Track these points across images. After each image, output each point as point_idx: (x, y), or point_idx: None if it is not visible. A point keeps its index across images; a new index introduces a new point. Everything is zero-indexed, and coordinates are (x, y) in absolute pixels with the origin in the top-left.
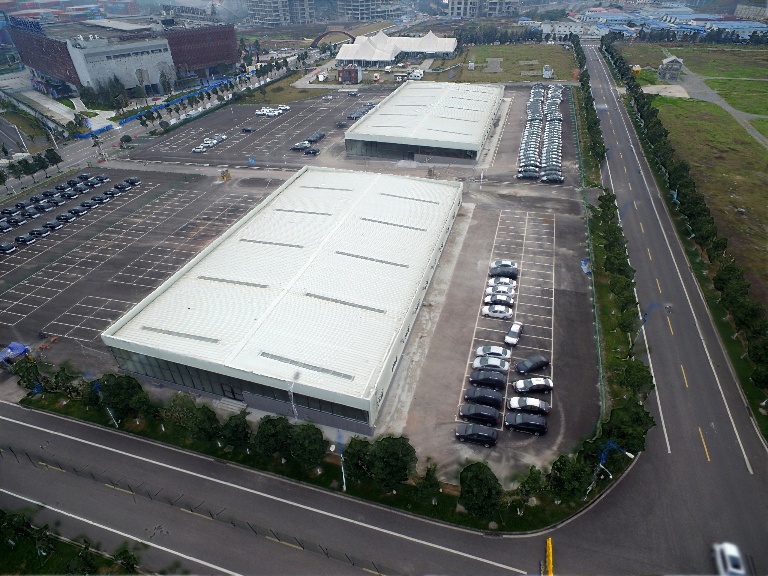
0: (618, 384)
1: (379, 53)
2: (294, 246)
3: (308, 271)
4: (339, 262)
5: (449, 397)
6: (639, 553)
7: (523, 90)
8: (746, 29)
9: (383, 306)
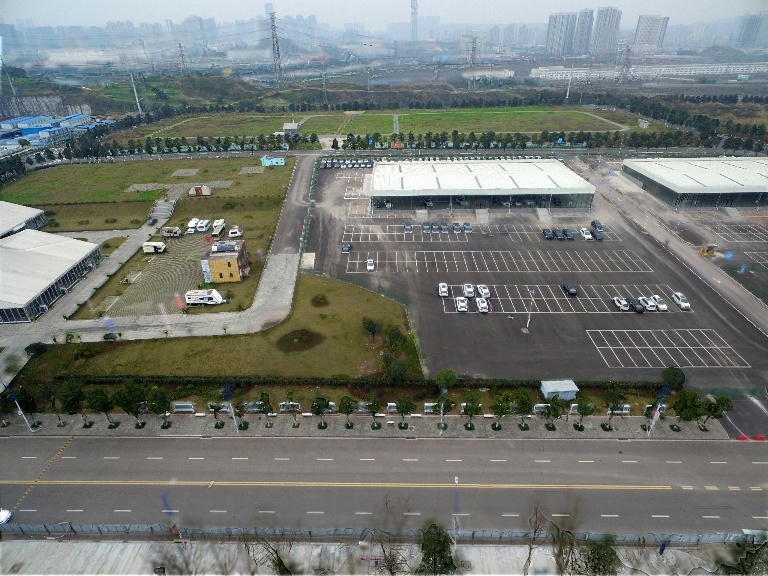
0: None
1: (53, 249)
2: None
3: None
4: (749, 167)
5: None
6: (750, 154)
7: (333, 171)
8: (74, 119)
9: None
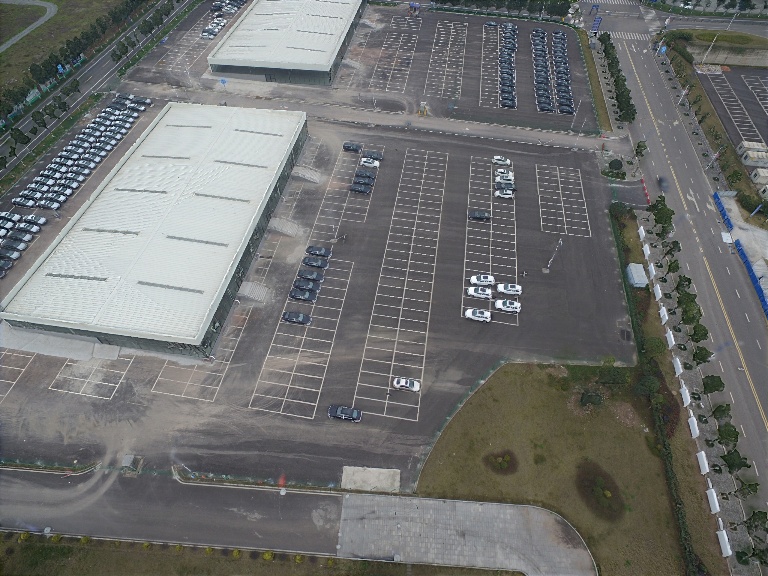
0: (190, 8)
1: None
2: (312, 15)
3: (300, 6)
4: None
5: (249, 5)
6: None
7: None
8: None
9: (267, 1)
